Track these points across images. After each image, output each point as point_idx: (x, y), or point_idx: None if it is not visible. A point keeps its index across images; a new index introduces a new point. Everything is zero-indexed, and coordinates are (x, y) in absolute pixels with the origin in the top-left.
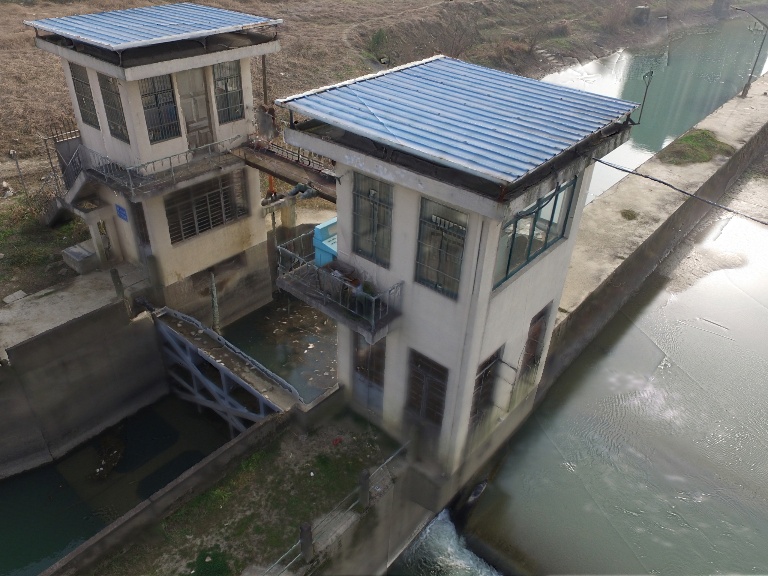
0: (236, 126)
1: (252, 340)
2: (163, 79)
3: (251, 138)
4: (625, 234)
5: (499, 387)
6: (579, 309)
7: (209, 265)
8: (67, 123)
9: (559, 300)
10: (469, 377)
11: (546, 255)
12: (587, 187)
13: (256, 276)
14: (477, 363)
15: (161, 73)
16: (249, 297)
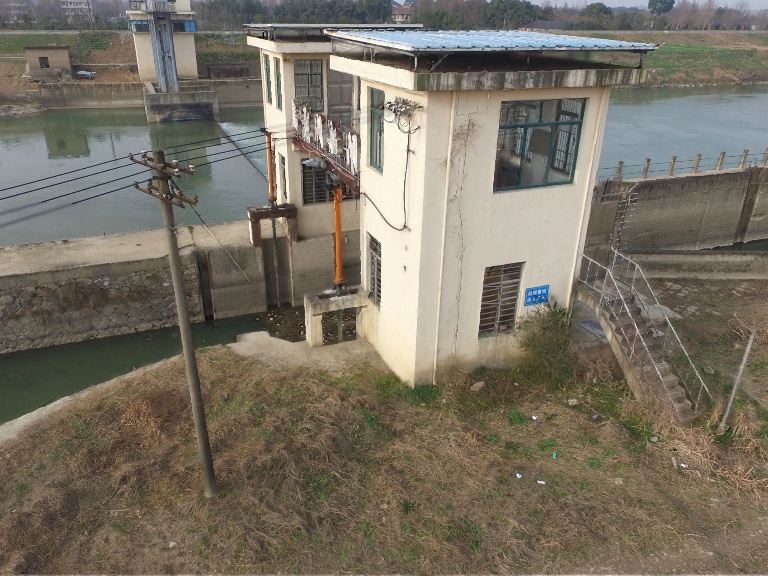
0: None
1: None
2: None
3: None
4: (7, 253)
5: None
6: None
7: None
8: (605, 183)
9: None
10: None
11: None
12: None
13: None
14: None
15: None
16: None
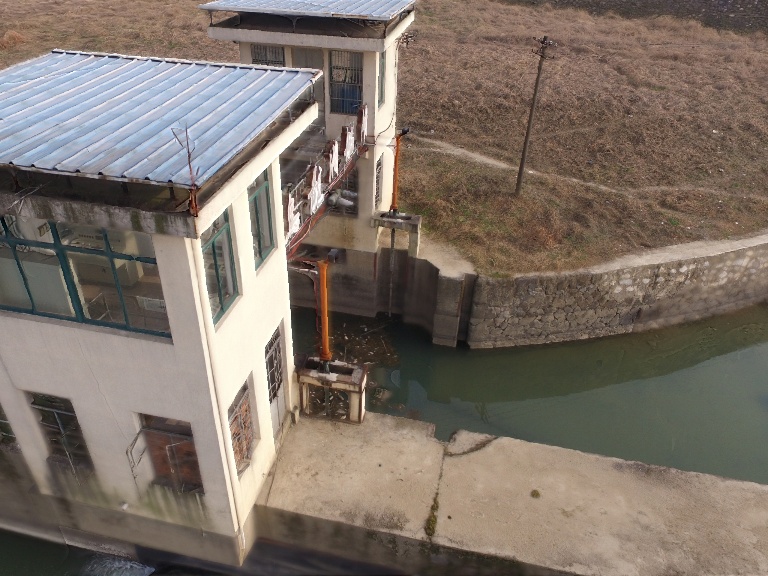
0: (351, 120)
1: (306, 330)
2: (276, 50)
3: (367, 139)
4: None
5: (97, 456)
6: (467, 556)
7: (304, 241)
8: None
9: (214, 436)
10: (1, 388)
11: (114, 333)
12: (188, 286)
13: (357, 281)
14: (10, 382)
15: (242, 39)
16: (346, 297)
